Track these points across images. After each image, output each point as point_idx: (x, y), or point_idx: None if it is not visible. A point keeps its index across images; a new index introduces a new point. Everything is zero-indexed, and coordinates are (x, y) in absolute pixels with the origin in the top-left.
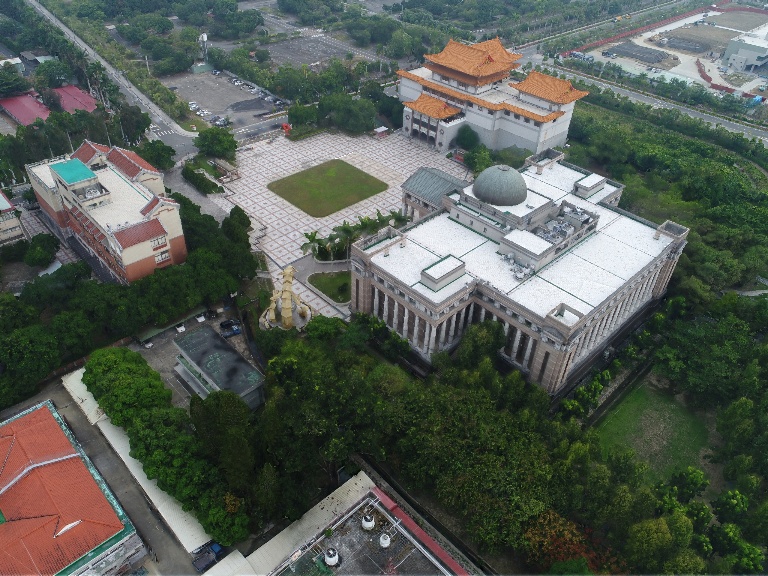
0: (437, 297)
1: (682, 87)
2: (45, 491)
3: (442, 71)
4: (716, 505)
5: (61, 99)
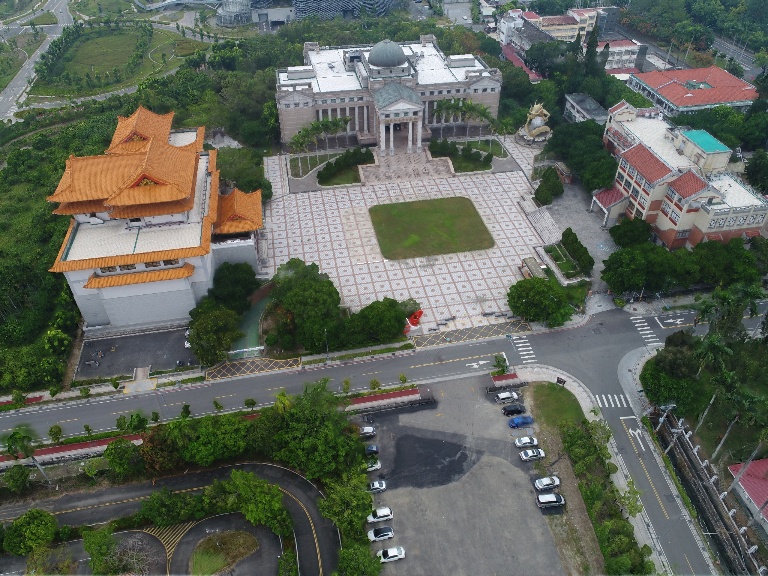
0: None
1: None
2: None
3: None
4: None
5: None
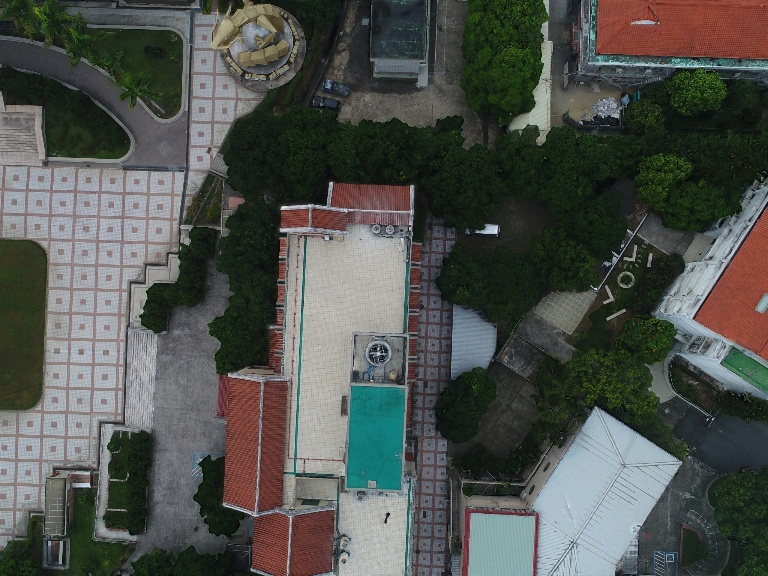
0: None
1: None
2: None
3: None
4: None
5: None
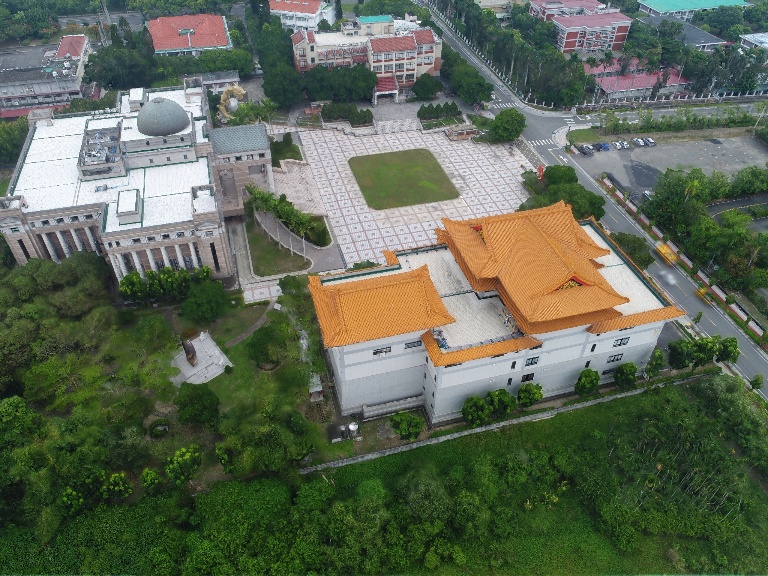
0: None
1: None
2: None
3: None
4: None
5: (628, 68)
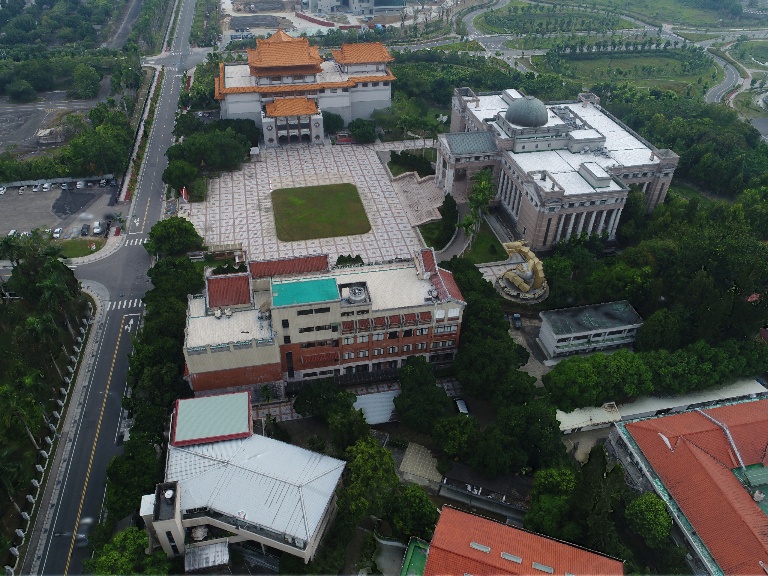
0: (615, 188)
1: (341, 34)
2: (749, 424)
3: (273, 72)
4: (760, 200)
5: None
